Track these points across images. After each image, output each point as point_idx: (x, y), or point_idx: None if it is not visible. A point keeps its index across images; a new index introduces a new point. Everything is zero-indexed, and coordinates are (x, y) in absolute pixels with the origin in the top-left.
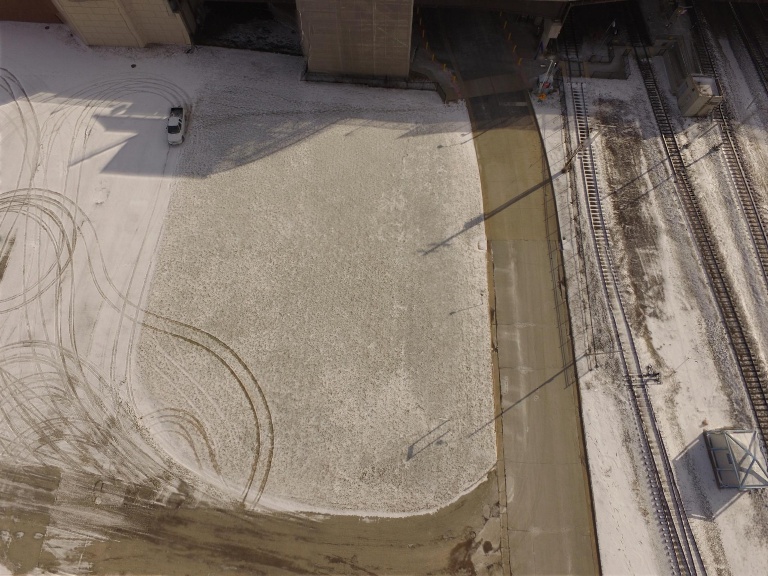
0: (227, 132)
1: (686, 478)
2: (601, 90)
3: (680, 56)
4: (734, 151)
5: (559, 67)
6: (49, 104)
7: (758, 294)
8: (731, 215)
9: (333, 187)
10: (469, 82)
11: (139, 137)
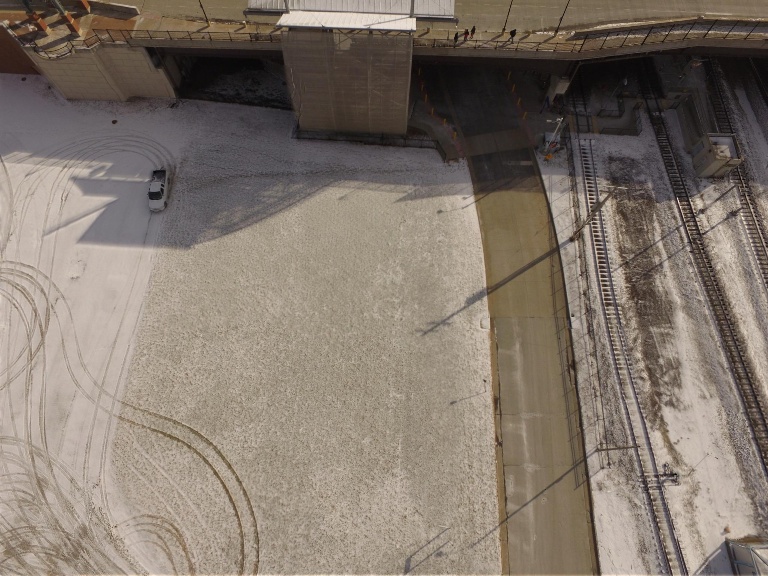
0: (213, 196)
1: None
2: (611, 147)
3: (695, 111)
4: (753, 216)
5: (566, 122)
6: (24, 165)
7: None
8: (751, 289)
9: (325, 258)
10: (471, 138)
11: (119, 202)
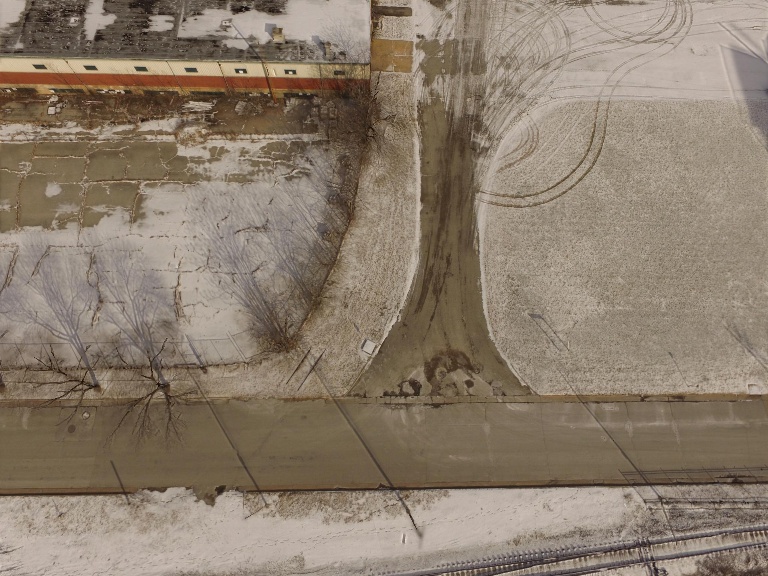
0: None
1: None
2: None
3: None
4: None
5: None
6: None
7: None
8: None
9: None
10: None
11: (766, 66)
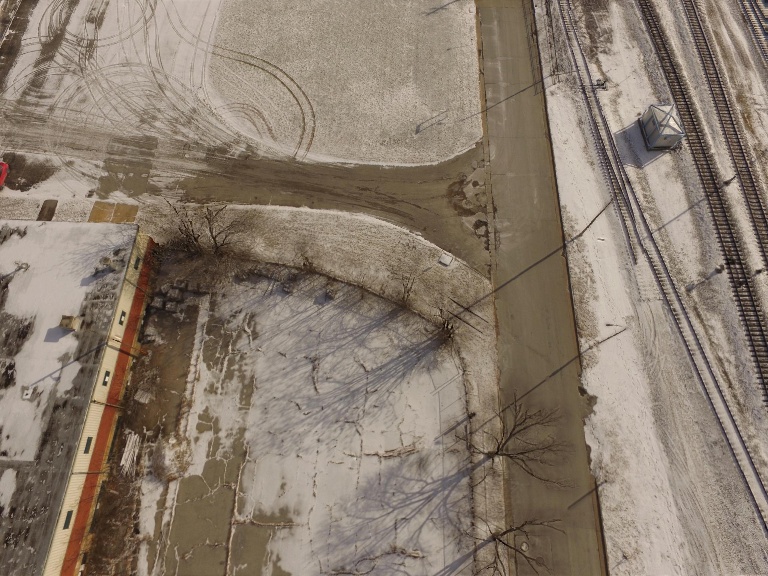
0: None
1: (623, 144)
2: None
3: None
4: None
5: None
6: None
7: (684, 37)
8: None
9: None
10: None
11: None
